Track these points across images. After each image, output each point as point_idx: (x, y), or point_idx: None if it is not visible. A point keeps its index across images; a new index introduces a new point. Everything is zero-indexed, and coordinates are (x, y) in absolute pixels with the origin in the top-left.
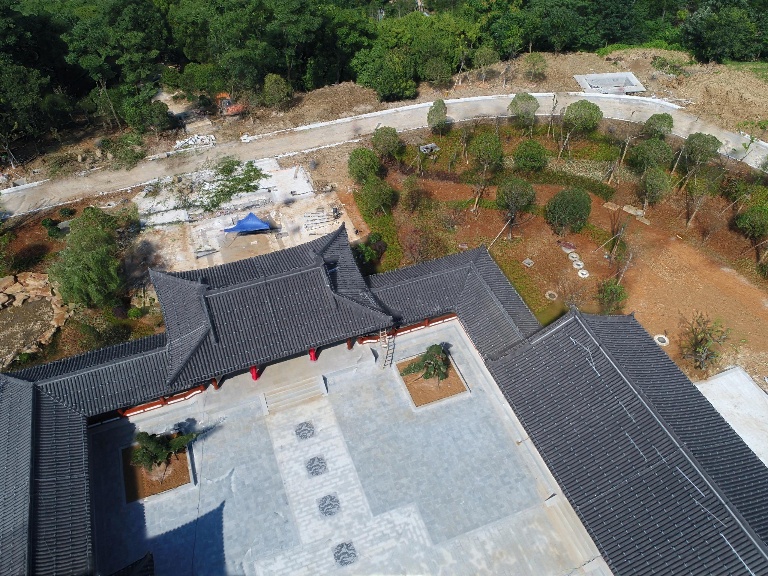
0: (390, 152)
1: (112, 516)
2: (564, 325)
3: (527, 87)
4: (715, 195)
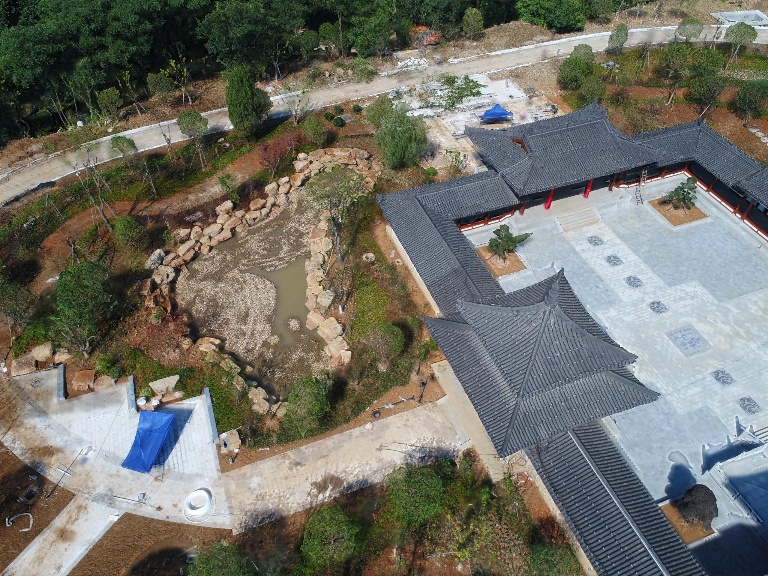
0: None
1: None
2: None
3: (675, 21)
4: None
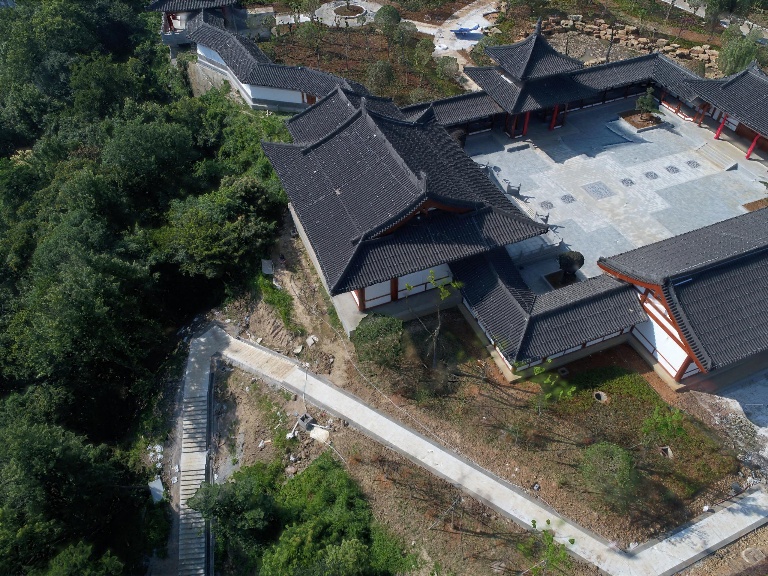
0: None
1: (608, 113)
2: None
3: None
4: None
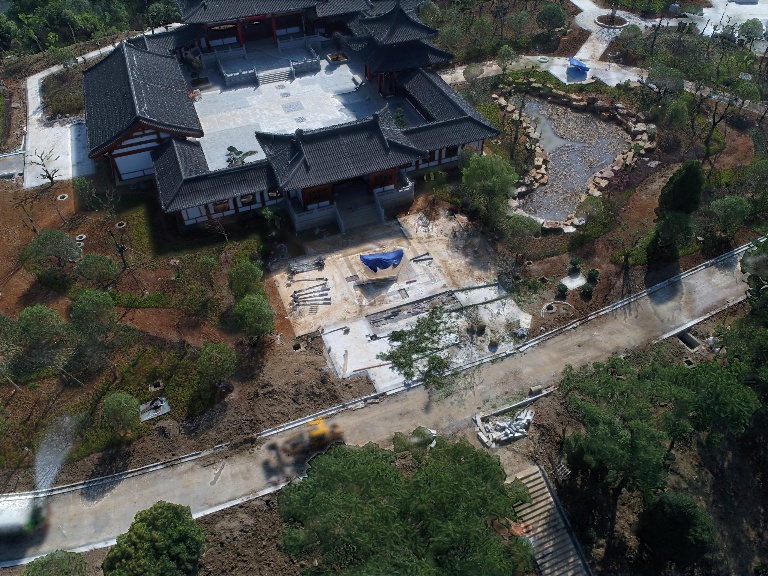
0: None
1: None
2: None
3: None
4: None
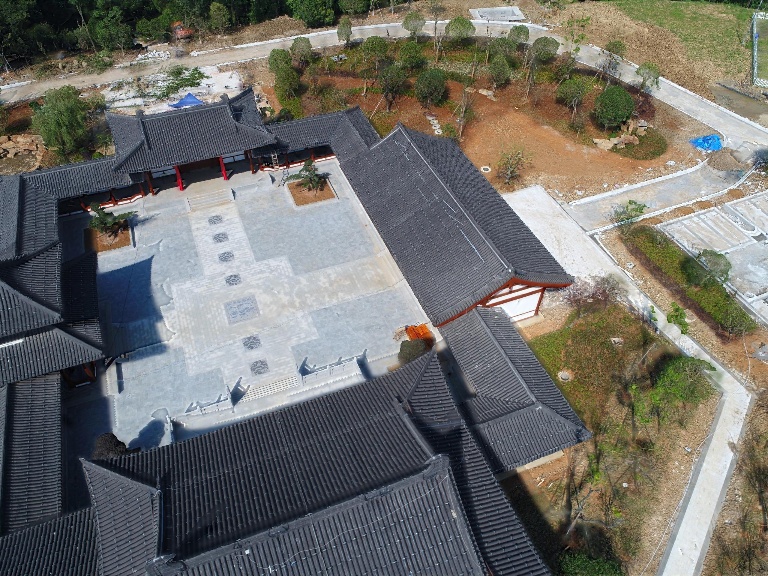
0: (306, 58)
1: None
2: (392, 135)
3: (428, 17)
4: (552, 82)
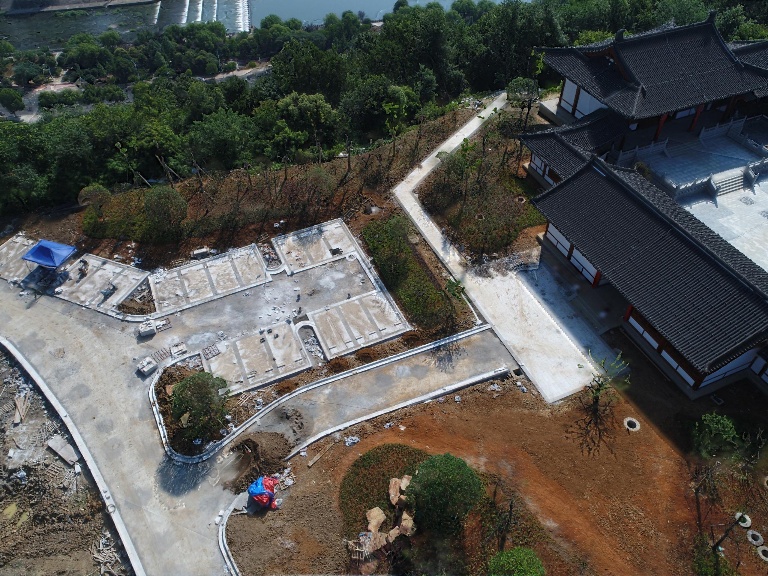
0: None
1: None
2: None
3: None
4: None
